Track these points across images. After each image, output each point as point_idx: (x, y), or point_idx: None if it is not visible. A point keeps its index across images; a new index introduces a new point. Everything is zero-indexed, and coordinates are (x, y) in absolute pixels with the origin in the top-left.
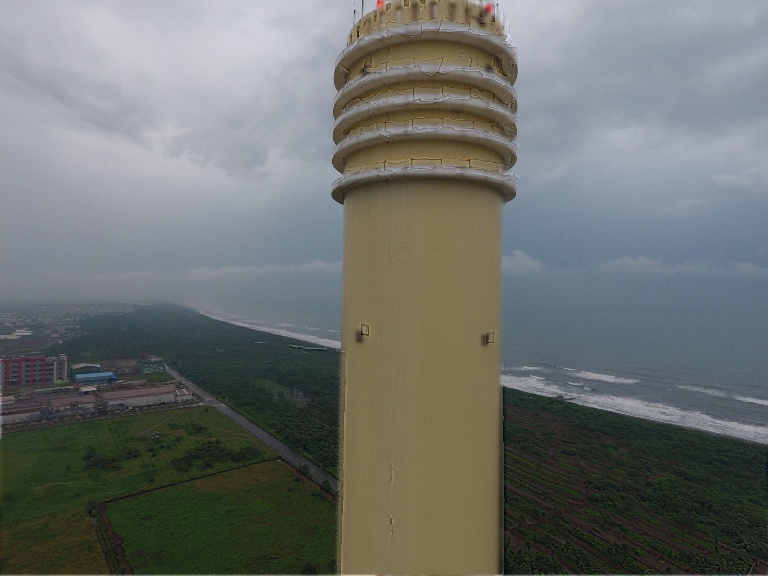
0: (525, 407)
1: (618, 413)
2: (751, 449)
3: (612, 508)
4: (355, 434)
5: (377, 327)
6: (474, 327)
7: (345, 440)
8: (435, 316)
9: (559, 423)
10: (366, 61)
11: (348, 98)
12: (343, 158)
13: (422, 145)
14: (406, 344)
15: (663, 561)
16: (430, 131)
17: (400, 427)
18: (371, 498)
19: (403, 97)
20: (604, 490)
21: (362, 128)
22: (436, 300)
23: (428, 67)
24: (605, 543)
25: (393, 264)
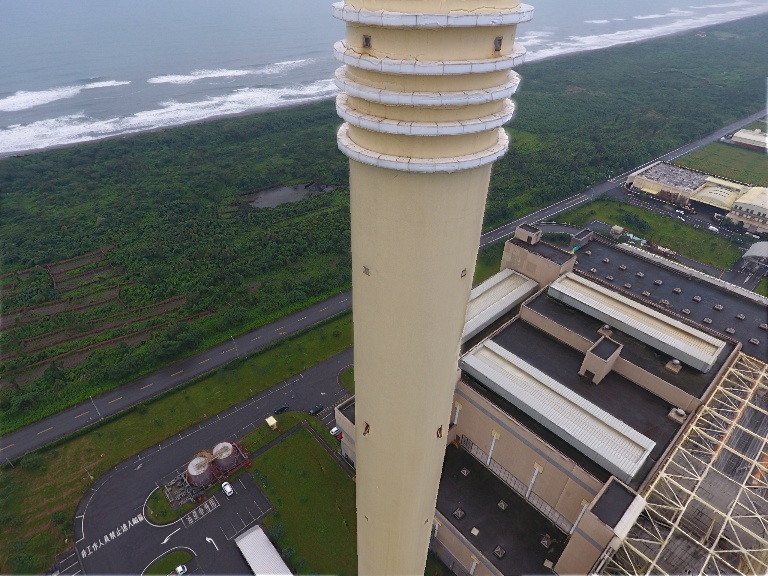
0: None
1: None
2: None
3: None
4: None
5: None
6: None
7: None
8: None
9: None
10: None
11: (479, 77)
12: (451, 139)
13: None
14: None
15: None
16: None
17: None
18: None
19: None
20: None
21: None
22: None
23: None
24: None
25: None
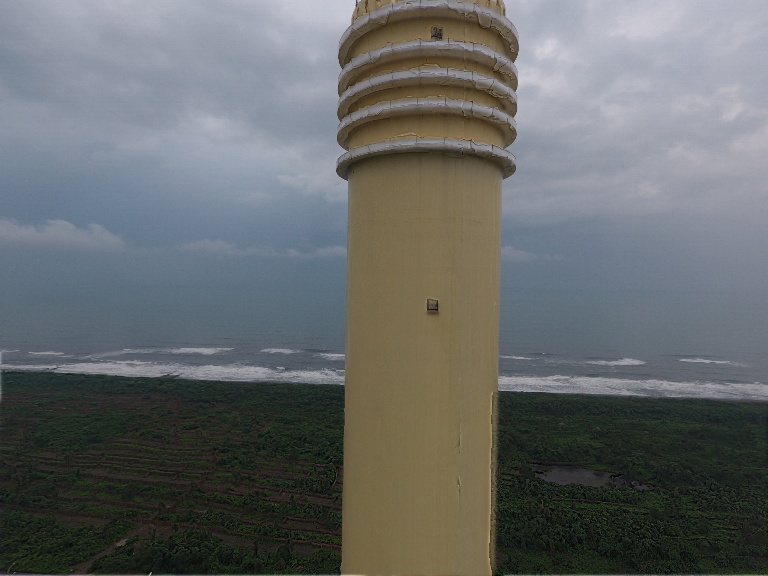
0: (134, 393)
1: (225, 381)
2: (320, 389)
3: (238, 465)
4: (416, 412)
5: (448, 301)
6: (495, 297)
7: (388, 424)
8: (488, 289)
9: (173, 402)
10: (436, 27)
11: (408, 56)
12: (385, 118)
13: (487, 133)
14: (475, 315)
15: (284, 493)
16: (498, 122)
17: (467, 393)
18: (439, 468)
19: (481, 82)
20: (229, 452)
21: (447, 99)
22: (489, 274)
23: (496, 63)
24: (240, 497)
25: (463, 240)
